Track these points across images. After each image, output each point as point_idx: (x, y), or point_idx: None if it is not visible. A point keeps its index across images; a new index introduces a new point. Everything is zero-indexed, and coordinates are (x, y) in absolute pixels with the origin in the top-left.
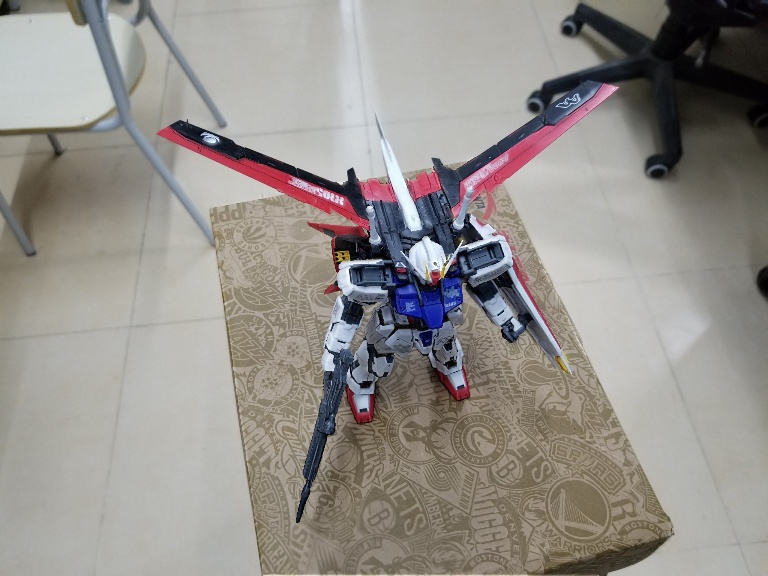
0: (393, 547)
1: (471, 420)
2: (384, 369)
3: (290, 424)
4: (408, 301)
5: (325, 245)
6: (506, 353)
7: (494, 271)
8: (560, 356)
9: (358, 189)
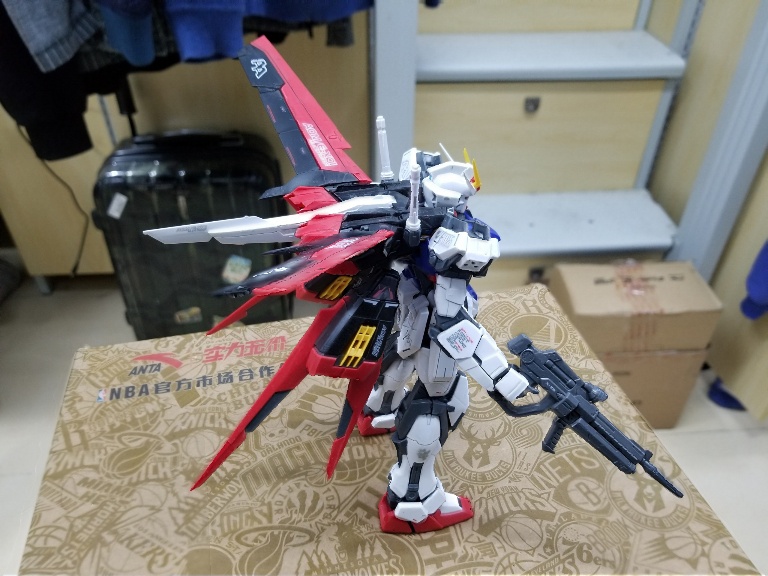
0: (617, 479)
1: None
2: None
3: None
4: None
5: (155, 568)
6: None
7: None
8: None
9: (316, 240)
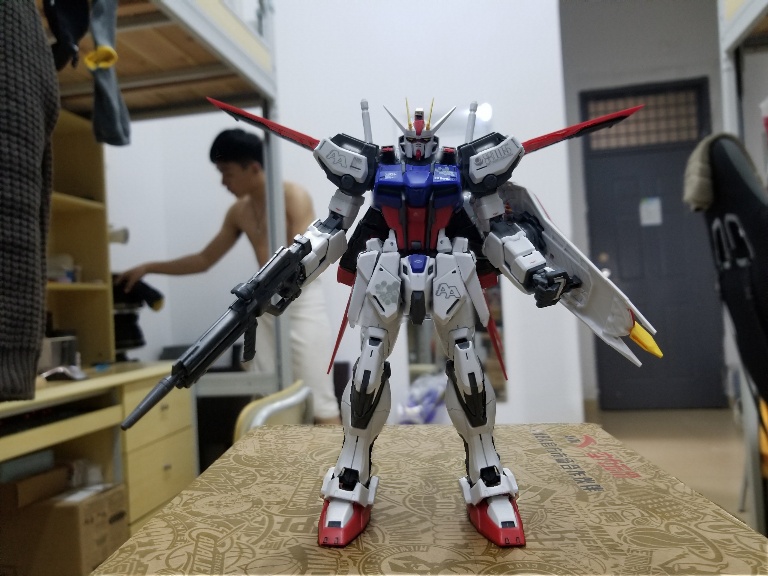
0: None
1: (521, 565)
2: (364, 361)
3: (214, 532)
4: (389, 172)
5: None
6: (599, 520)
7: (498, 151)
8: (626, 301)
9: None
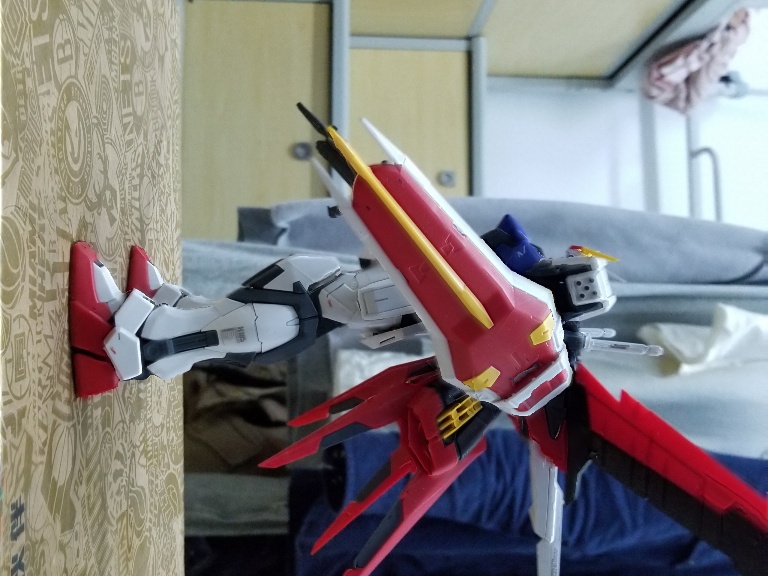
0: None
1: None
2: None
3: None
4: None
5: None
6: None
7: None
8: None
9: None
